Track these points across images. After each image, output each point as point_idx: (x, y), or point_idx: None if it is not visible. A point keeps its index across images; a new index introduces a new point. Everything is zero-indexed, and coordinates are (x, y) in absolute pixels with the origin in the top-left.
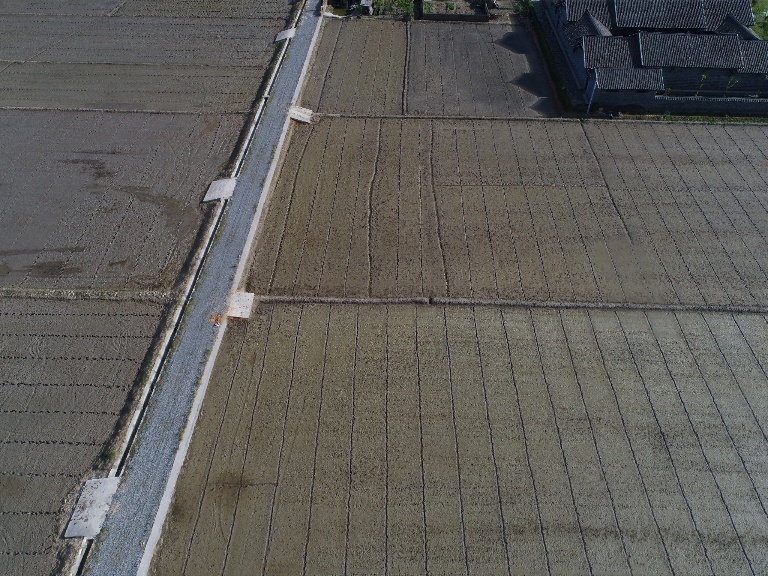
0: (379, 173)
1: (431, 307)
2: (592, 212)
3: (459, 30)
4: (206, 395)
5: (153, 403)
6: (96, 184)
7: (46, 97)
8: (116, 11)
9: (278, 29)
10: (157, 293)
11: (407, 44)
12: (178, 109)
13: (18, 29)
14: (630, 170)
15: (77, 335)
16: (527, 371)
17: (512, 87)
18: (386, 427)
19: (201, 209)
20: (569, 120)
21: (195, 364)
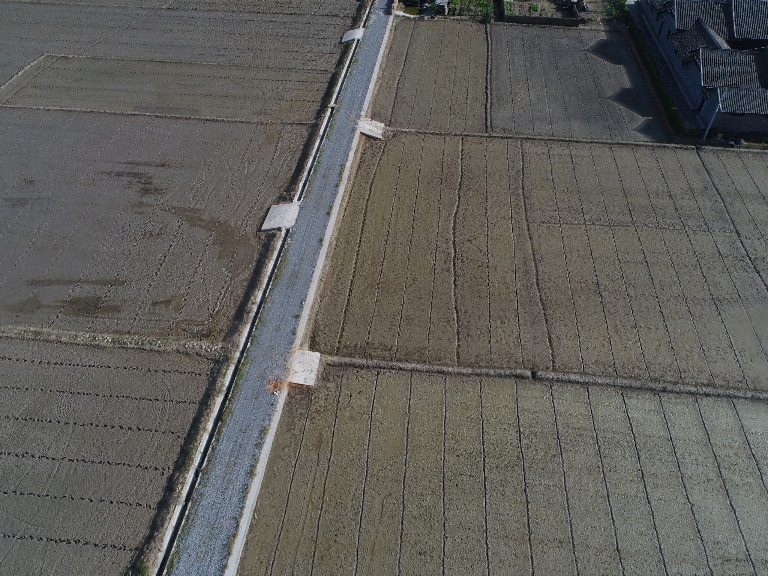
0: (463, 203)
1: (535, 384)
2: (723, 266)
3: (545, 35)
4: (262, 489)
5: (197, 498)
6: (142, 202)
7: (93, 97)
8: (171, 3)
9: (344, 28)
10: (206, 345)
11: (488, 49)
12: (235, 116)
13: (68, 20)
14: (763, 213)
15: (111, 395)
16: (663, 483)
17: (611, 104)
18: (487, 553)
19: (258, 239)
20: (683, 147)
21: (249, 446)
